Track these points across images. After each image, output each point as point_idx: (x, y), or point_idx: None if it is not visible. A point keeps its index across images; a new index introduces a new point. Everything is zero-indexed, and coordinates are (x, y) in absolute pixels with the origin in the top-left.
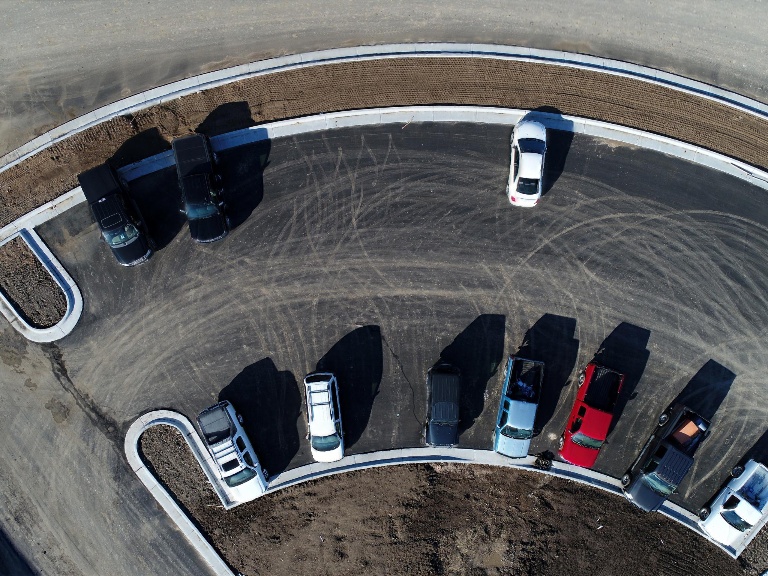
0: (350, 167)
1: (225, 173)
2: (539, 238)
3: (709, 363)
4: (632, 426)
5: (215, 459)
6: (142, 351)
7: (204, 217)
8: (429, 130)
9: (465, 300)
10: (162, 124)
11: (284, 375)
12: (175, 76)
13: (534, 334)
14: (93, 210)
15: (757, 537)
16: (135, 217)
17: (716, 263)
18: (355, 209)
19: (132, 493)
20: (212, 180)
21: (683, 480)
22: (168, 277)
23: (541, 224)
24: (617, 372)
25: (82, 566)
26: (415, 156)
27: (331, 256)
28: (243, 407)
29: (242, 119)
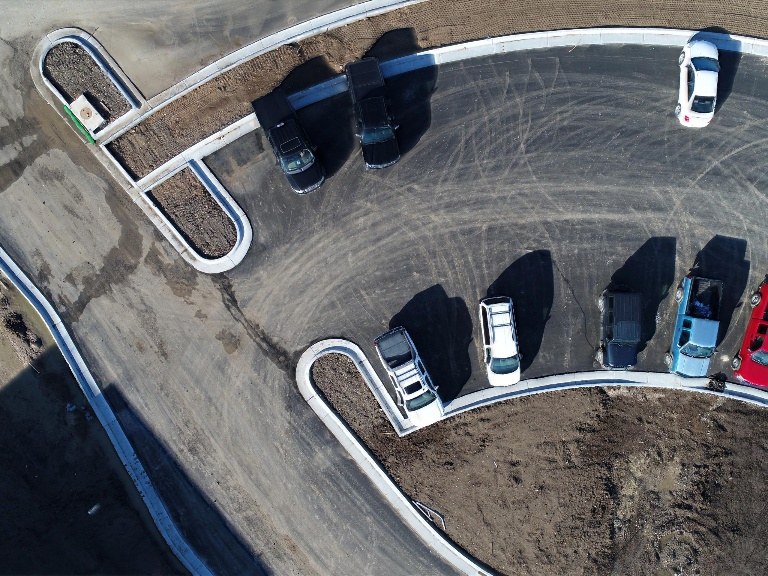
0: (518, 92)
1: (393, 100)
2: (708, 159)
3: None
4: None
5: (398, 382)
6: (312, 280)
7: (380, 141)
8: (596, 53)
9: (635, 223)
10: (329, 52)
11: (455, 301)
12: (341, 3)
13: (705, 256)
14: (272, 135)
15: None
16: (309, 143)
17: None
18: (523, 134)
19: (304, 422)
20: (387, 104)
21: None
22: (337, 205)
23: (710, 145)
24: None
25: (256, 496)
26: (583, 79)
27: (500, 181)
28: (414, 334)
29: (409, 45)
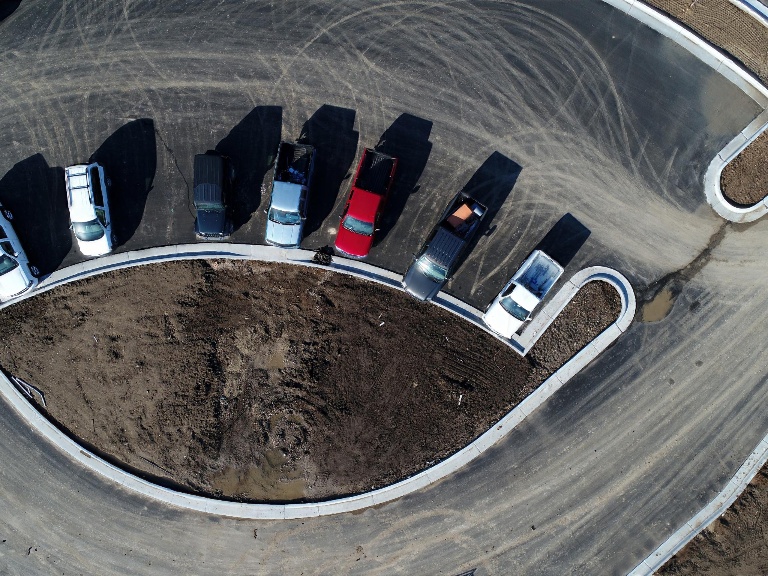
0: None
1: None
2: (316, 27)
3: (494, 155)
4: (415, 220)
5: None
6: None
7: None
8: None
9: (240, 91)
10: None
11: (55, 171)
12: None
13: (312, 126)
14: None
15: (547, 335)
16: None
17: (500, 52)
18: None
19: None
20: None
21: (469, 276)
22: None
23: (318, 13)
24: (389, 156)
25: None
26: None
27: (102, 48)
28: (14, 205)
29: None
